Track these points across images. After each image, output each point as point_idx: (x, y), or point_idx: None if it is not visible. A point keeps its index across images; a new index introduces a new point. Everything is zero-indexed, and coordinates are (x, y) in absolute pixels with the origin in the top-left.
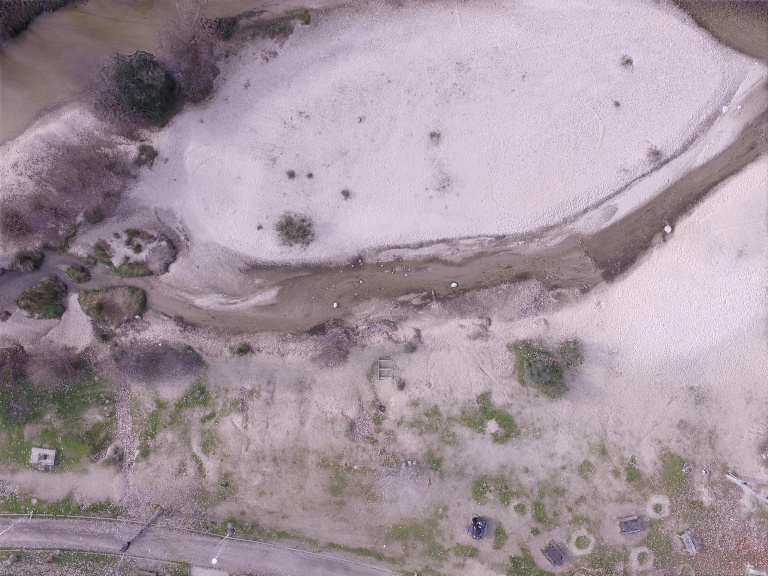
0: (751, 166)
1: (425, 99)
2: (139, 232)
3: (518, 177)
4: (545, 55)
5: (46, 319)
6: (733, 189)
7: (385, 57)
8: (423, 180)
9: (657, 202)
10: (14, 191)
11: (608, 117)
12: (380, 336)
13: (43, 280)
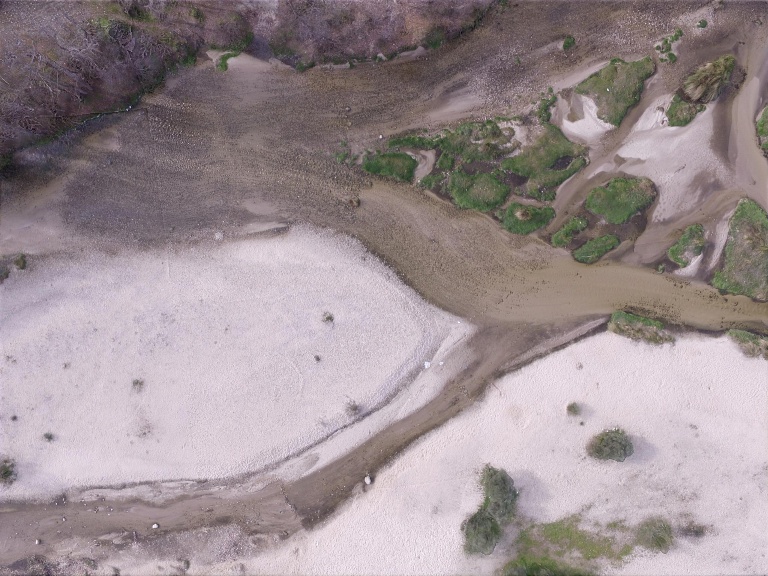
0: (452, 422)
1: (129, 348)
2: None
3: (218, 426)
4: (248, 309)
5: None
6: (432, 444)
7: (93, 305)
8: (125, 426)
9: (358, 453)
10: None
11: (308, 371)
12: (79, 574)
13: None
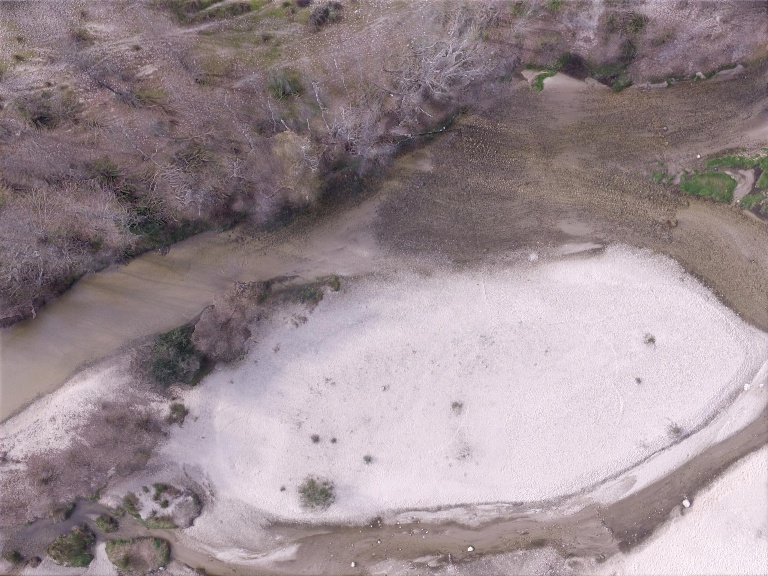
0: None
1: (448, 370)
2: (167, 487)
3: (537, 449)
4: (568, 331)
5: (74, 567)
6: (753, 467)
7: (411, 327)
8: (444, 448)
9: (676, 475)
10: (51, 445)
11: (629, 393)
12: None
13: (73, 529)
